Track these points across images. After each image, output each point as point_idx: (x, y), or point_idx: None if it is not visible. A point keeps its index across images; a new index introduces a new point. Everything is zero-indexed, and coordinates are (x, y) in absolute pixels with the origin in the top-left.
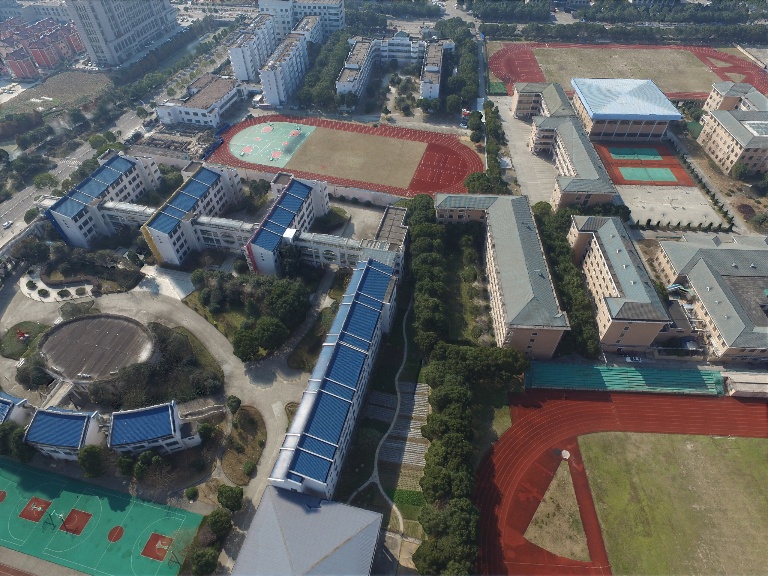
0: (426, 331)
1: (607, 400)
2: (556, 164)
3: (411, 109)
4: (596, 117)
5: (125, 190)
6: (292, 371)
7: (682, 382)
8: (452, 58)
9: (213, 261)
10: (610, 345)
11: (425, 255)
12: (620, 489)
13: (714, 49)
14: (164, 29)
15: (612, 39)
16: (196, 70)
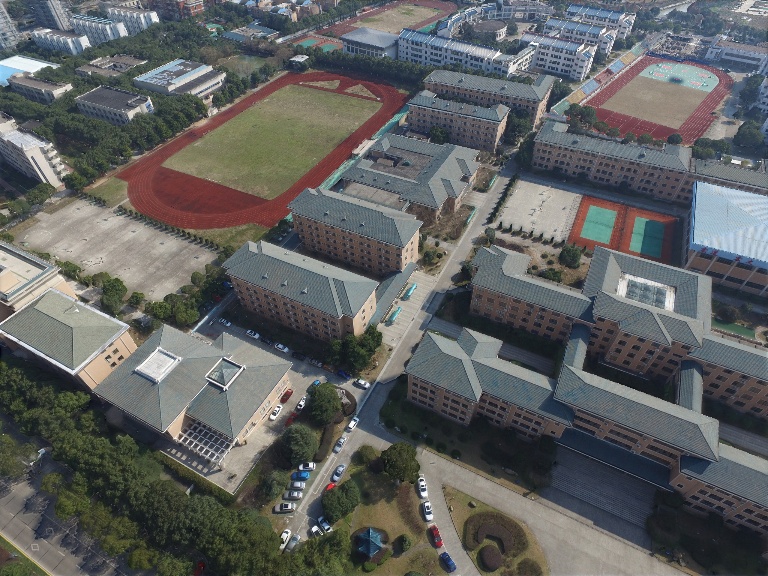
0: None
1: (392, 114)
2: None
3: None
4: None
5: None
6: None
7: (384, 130)
8: None
9: None
10: None
11: None
12: (357, 103)
13: None
14: None
15: None
16: None
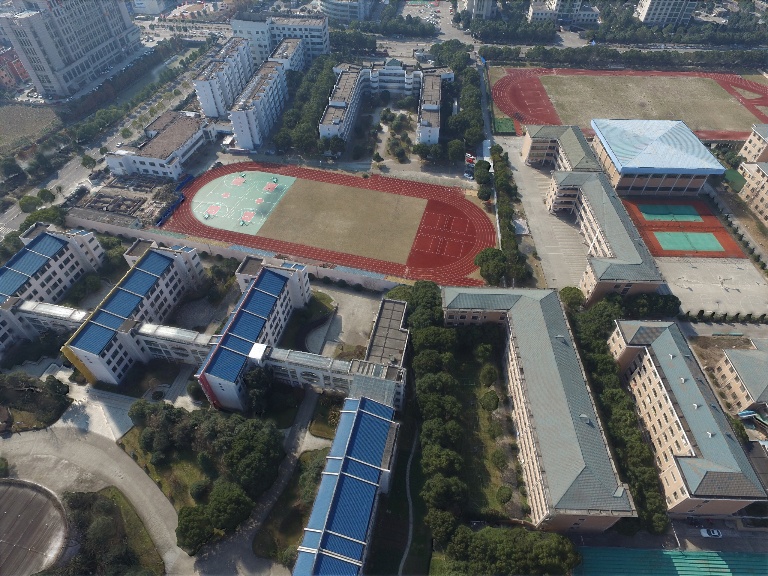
0: (439, 507)
1: None
2: (581, 229)
3: (406, 154)
4: (625, 171)
5: (54, 277)
6: (259, 562)
7: None
8: (451, 90)
9: (161, 379)
10: (680, 514)
11: (433, 379)
12: None
13: (738, 76)
14: (125, 51)
15: (626, 64)
16: (158, 104)
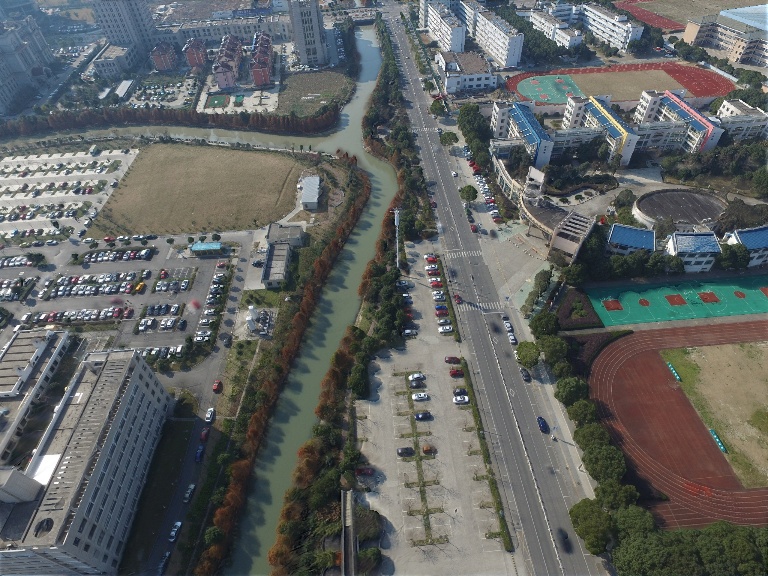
0: None
1: None
2: (767, 64)
3: None
4: None
5: None
6: None
7: None
8: None
9: None
10: None
11: None
12: None
13: None
14: None
15: None
16: None
